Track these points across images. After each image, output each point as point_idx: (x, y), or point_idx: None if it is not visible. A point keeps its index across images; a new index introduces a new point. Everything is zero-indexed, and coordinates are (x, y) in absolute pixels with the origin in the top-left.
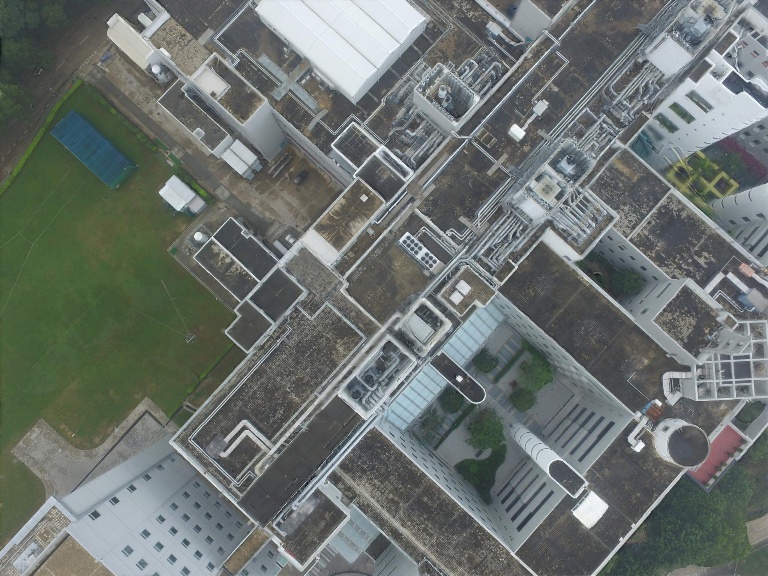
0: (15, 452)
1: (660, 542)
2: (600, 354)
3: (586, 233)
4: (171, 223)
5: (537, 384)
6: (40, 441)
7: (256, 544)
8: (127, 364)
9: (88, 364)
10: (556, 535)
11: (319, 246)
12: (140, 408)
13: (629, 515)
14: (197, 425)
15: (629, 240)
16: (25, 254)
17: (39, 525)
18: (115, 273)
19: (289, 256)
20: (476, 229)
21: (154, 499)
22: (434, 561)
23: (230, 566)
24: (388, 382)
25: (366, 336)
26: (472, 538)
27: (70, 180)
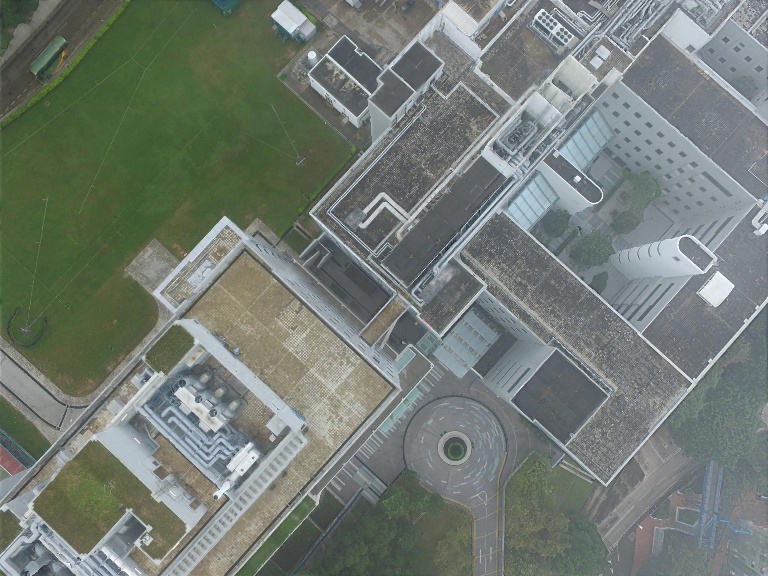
0: (128, 271)
1: (764, 360)
2: (721, 145)
3: (718, 8)
4: (280, 50)
5: (648, 194)
6: (153, 260)
7: (393, 315)
8: (238, 186)
9: (200, 185)
10: (681, 317)
11: (458, 18)
12: (251, 229)
13: (753, 298)
14: (334, 200)
15: (749, 33)
16: (138, 79)
17: (212, 243)
18: (226, 98)
19: (426, 33)
20: (606, 11)
21: (292, 272)
22: (562, 342)
23: (368, 336)
24: (525, 152)
25: (499, 115)
26: (599, 320)
27: (181, 8)
